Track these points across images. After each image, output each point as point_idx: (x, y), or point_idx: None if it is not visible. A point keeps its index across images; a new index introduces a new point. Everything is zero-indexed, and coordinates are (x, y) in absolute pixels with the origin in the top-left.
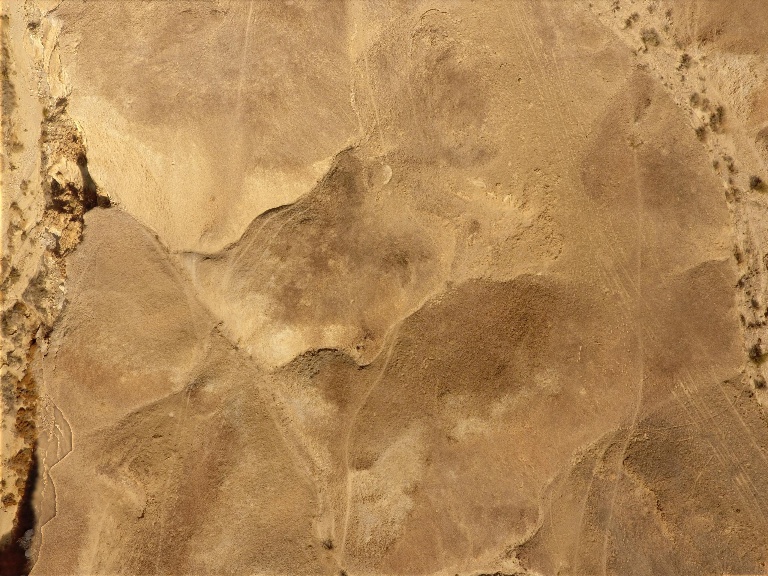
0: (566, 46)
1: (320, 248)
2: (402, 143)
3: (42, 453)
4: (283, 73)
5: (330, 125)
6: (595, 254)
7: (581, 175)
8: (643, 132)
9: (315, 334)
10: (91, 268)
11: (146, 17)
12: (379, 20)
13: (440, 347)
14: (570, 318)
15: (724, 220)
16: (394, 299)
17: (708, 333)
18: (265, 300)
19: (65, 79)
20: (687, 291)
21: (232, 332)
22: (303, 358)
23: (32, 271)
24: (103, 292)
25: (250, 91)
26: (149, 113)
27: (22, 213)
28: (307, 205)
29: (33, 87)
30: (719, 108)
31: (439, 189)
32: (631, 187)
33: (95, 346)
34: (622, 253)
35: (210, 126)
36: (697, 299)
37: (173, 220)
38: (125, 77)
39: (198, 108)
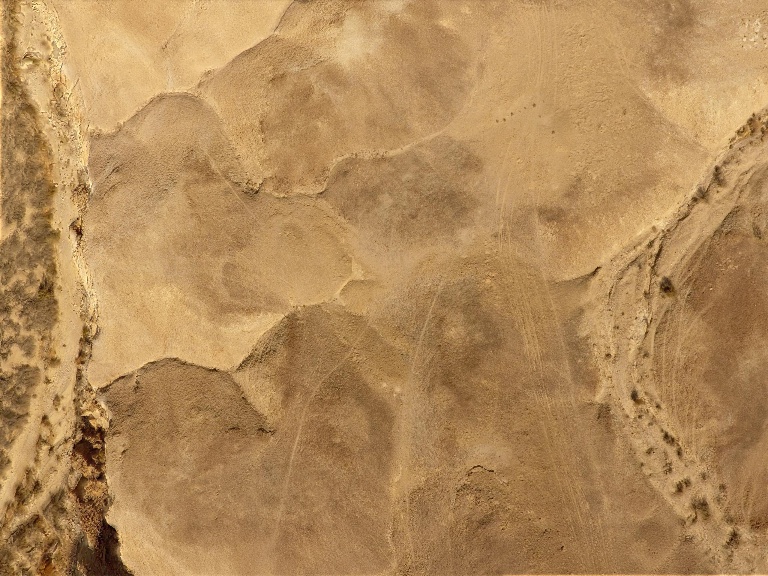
0: (613, 512)
1: None
2: None
3: None
4: (323, 509)
5: (365, 561)
6: None
7: None
8: None
9: None
10: None
11: (194, 430)
12: (425, 468)
13: None
14: None
15: None
16: None
17: None
18: None
19: (108, 482)
20: None
21: None
22: None
23: (55, 488)
24: None
25: (288, 523)
26: (186, 535)
27: (52, 428)
28: None
29: (76, 302)
30: None
31: None
32: None
33: None
34: None
35: (245, 553)
36: None
37: None
38: (167, 496)
39: (235, 534)
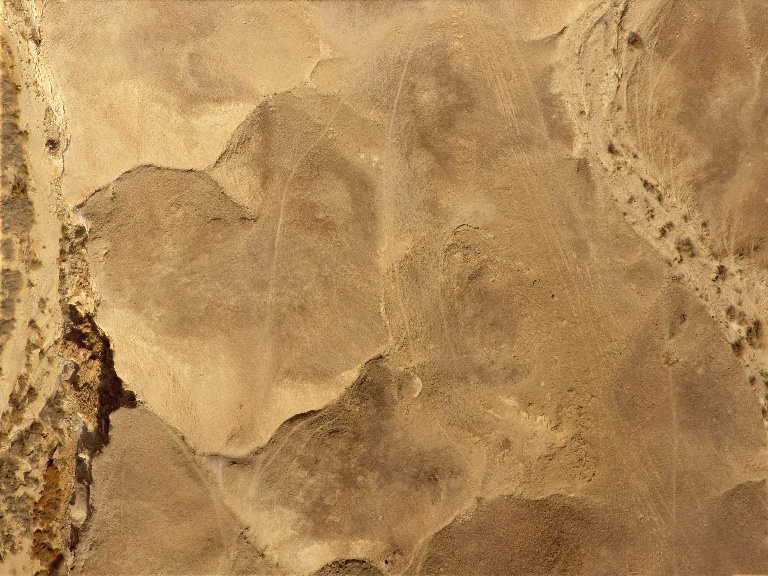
0: (600, 260)
1: (349, 464)
2: (432, 356)
3: (58, 575)
4: (313, 286)
5: (360, 336)
6: (629, 478)
7: (615, 394)
8: (678, 349)
9: (343, 547)
10: (117, 474)
11: (175, 225)
12: (410, 234)
13: (470, 567)
14: (604, 545)
15: (761, 441)
16: (424, 516)
17: (745, 562)
18: (293, 515)
19: (93, 286)
20: (723, 516)
21: (258, 538)
22: (330, 569)
23: (49, 390)
24: (129, 502)
25: (279, 304)
26: (178, 326)
27: (40, 331)
28: (335, 413)
29: (52, 203)
30: (756, 322)
31: (470, 405)
32: (666, 407)
33: (122, 562)
34: (657, 477)
35: (239, 338)
36: (734, 525)
37: (200, 424)
38: (154, 289)
39: (227, 321)
